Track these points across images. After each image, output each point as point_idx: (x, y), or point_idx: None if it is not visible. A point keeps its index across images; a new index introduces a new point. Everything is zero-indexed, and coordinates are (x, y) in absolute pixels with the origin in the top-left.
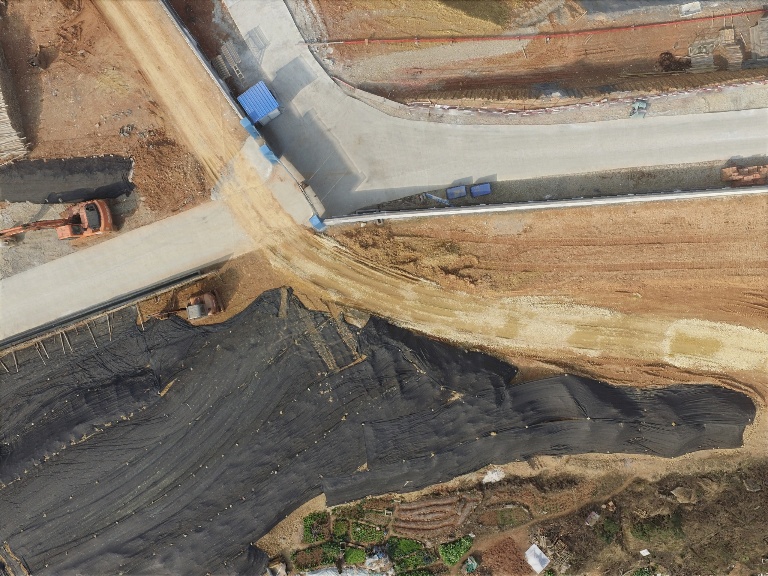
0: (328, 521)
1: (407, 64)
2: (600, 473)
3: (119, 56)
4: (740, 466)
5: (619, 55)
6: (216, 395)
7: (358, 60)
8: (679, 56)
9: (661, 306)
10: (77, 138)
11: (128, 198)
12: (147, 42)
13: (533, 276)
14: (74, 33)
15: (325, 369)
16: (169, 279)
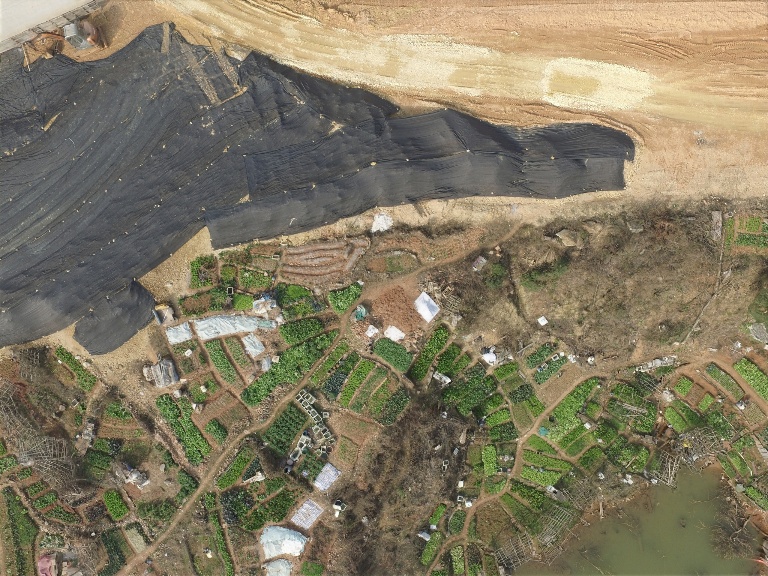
0: (215, 266)
1: None
2: (486, 216)
3: None
4: (624, 209)
5: None
6: (99, 130)
7: None
8: None
9: (539, 45)
10: None
11: None
12: None
13: (411, 12)
14: None
15: (207, 102)
16: None
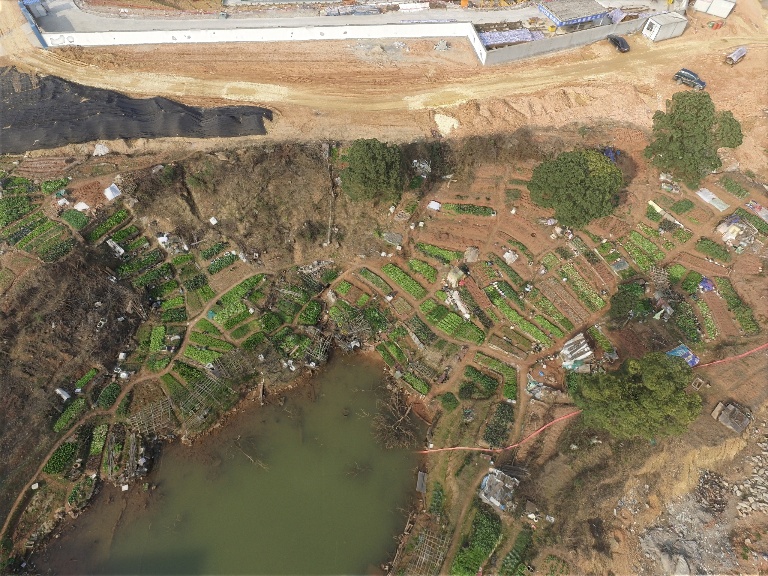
0: None
1: None
2: (170, 146)
3: None
4: (265, 144)
5: None
6: None
7: (96, 6)
8: None
9: (225, 77)
10: None
11: None
12: None
13: None
14: None
15: (13, 92)
16: None
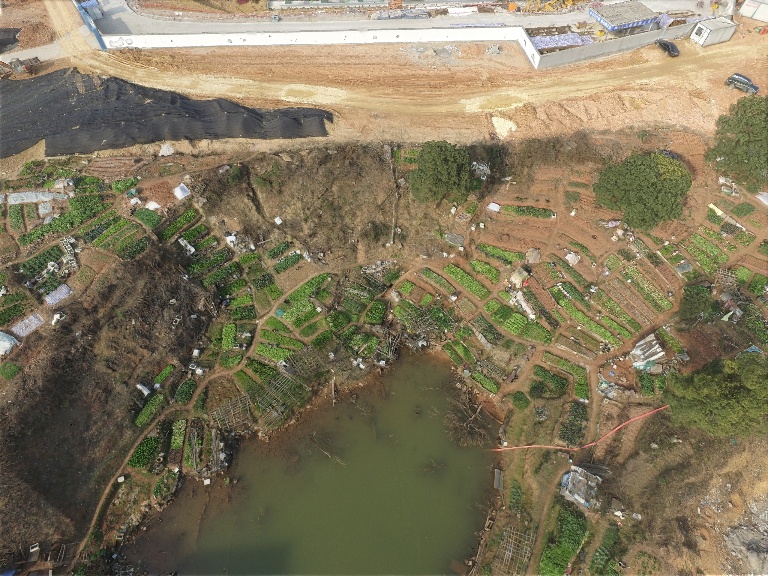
0: (42, 166)
1: None
2: (235, 147)
3: (39, 6)
4: (327, 145)
5: None
6: (7, 103)
7: (150, 9)
8: None
9: None
10: (0, 24)
11: (12, 45)
12: (54, 3)
13: None
14: (23, 1)
15: (77, 93)
16: None
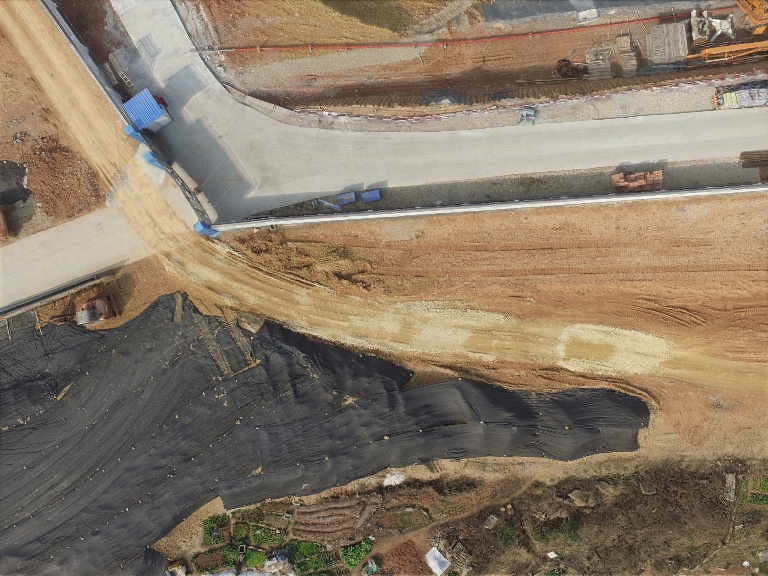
0: (228, 524)
1: (301, 71)
2: (498, 476)
3: (12, 63)
4: (637, 469)
5: (517, 62)
6: (112, 399)
7: (250, 67)
8: (577, 63)
9: (555, 311)
10: None
11: (25, 204)
12: (40, 50)
13: (426, 281)
14: None
15: (220, 373)
16: (66, 284)
